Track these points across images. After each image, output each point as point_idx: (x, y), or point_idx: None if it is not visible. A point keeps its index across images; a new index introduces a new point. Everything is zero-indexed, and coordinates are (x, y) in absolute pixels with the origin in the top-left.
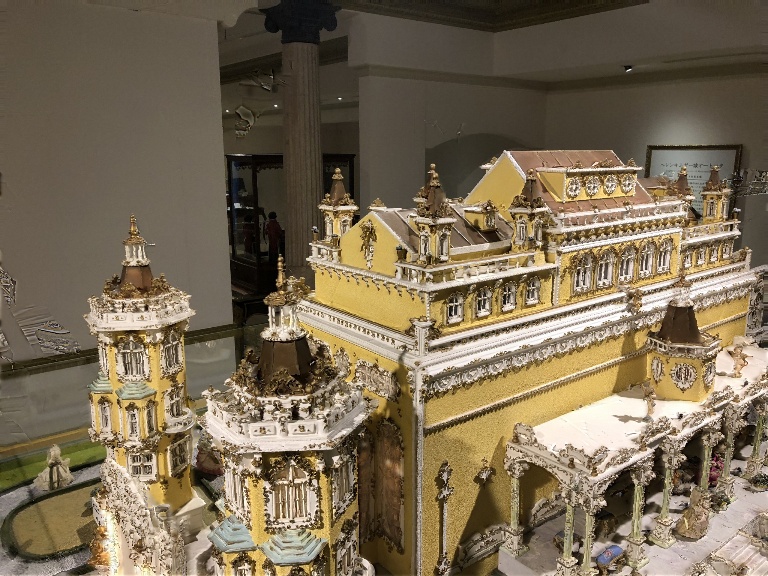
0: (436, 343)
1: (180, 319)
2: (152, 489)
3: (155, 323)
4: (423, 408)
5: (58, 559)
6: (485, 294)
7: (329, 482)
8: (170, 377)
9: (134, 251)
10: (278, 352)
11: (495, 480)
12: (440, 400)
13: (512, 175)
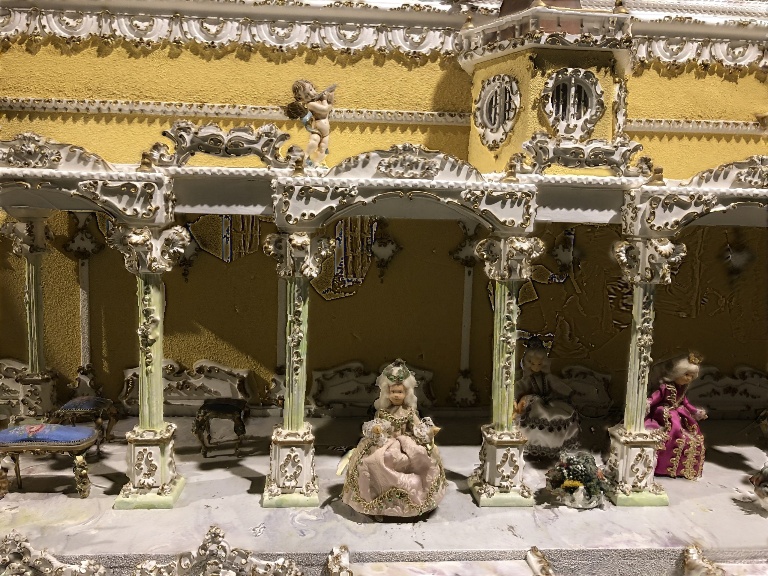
0: None
1: None
2: None
3: None
4: None
5: None
6: None
7: None
8: None
9: None
10: None
11: (17, 266)
12: None
13: None
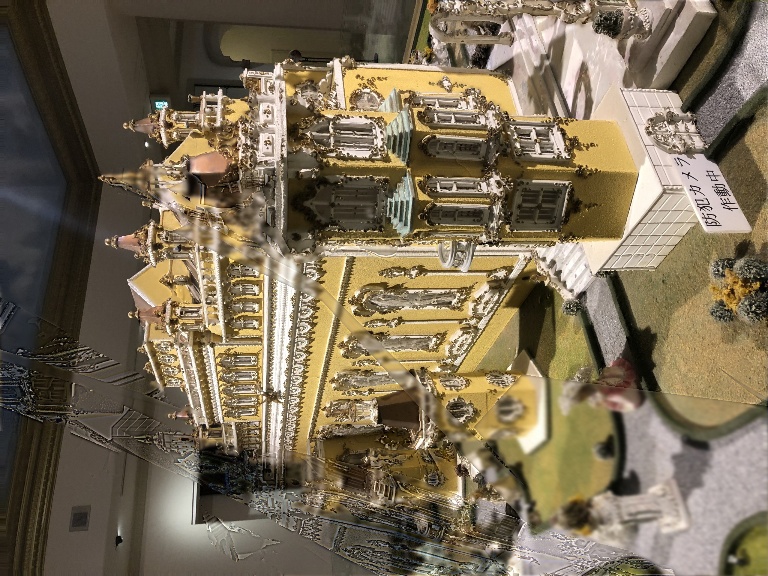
0: None
1: None
2: None
3: None
4: None
5: None
6: None
7: None
8: None
9: None
10: None
11: None
12: None
13: (152, 277)
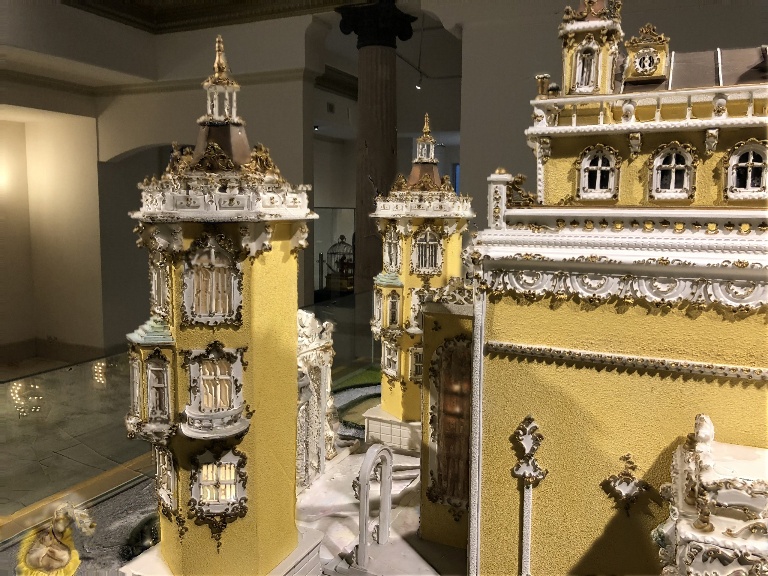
0: (517, 212)
1: (430, 215)
2: (396, 387)
3: (403, 213)
4: (487, 310)
5: (347, 427)
6: (684, 160)
7: (181, 275)
8: (421, 276)
9: (420, 149)
10: (198, 138)
11: (658, 514)
12: (524, 309)
13: None
